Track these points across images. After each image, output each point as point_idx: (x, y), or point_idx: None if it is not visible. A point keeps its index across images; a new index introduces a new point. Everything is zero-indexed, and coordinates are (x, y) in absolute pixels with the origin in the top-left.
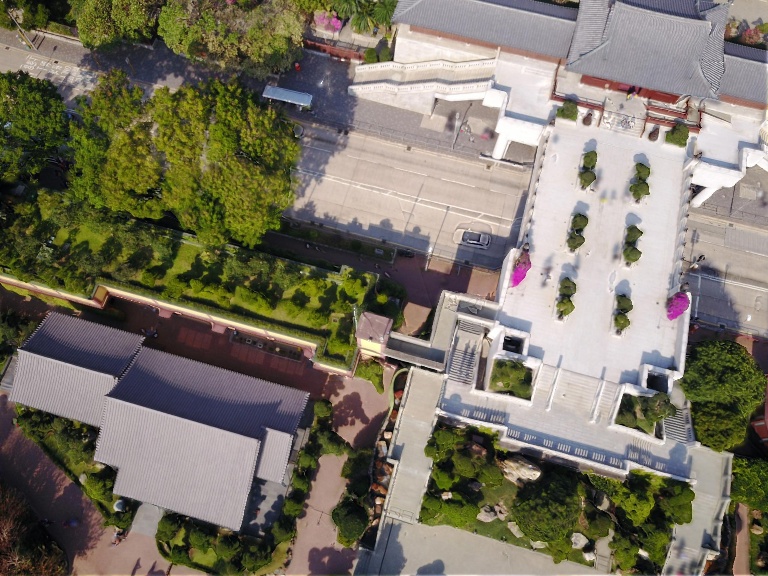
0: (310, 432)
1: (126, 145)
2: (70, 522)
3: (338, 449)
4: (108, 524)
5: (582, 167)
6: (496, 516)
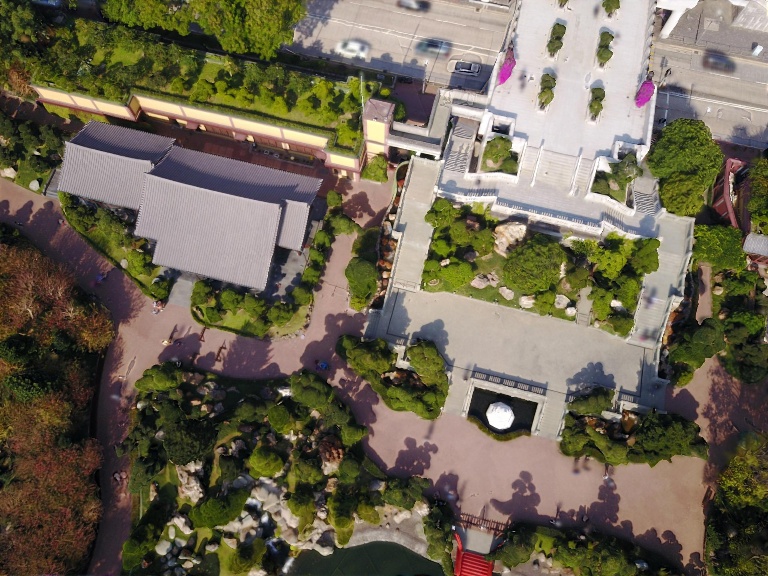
0: (323, 223)
1: None
2: (114, 298)
3: (349, 224)
4: (149, 291)
5: None
6: (489, 282)
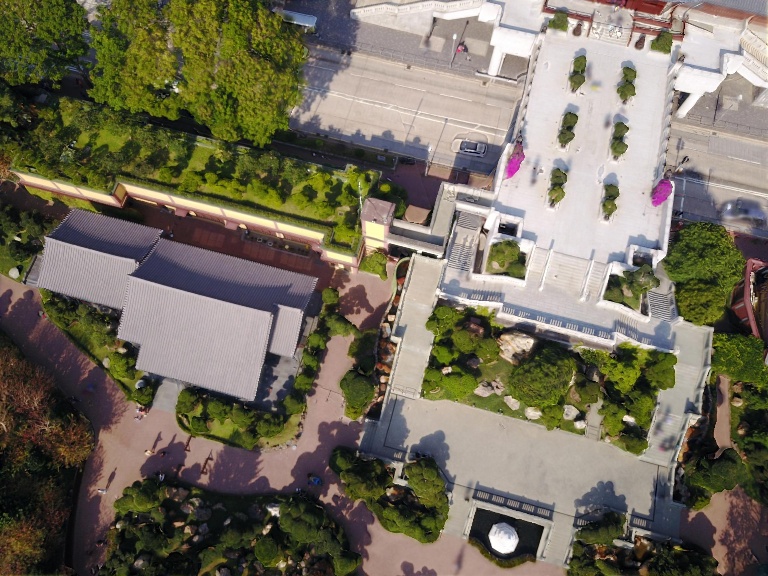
0: (318, 320)
1: (145, 41)
2: (95, 401)
3: (345, 328)
4: (131, 398)
5: (572, 72)
6: (493, 390)
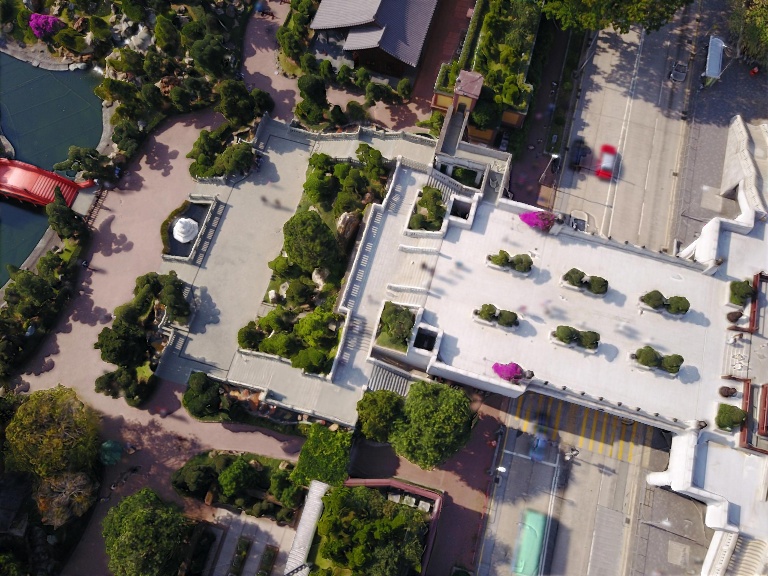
0: None
1: None
2: None
3: (369, 90)
4: None
5: None
6: None
